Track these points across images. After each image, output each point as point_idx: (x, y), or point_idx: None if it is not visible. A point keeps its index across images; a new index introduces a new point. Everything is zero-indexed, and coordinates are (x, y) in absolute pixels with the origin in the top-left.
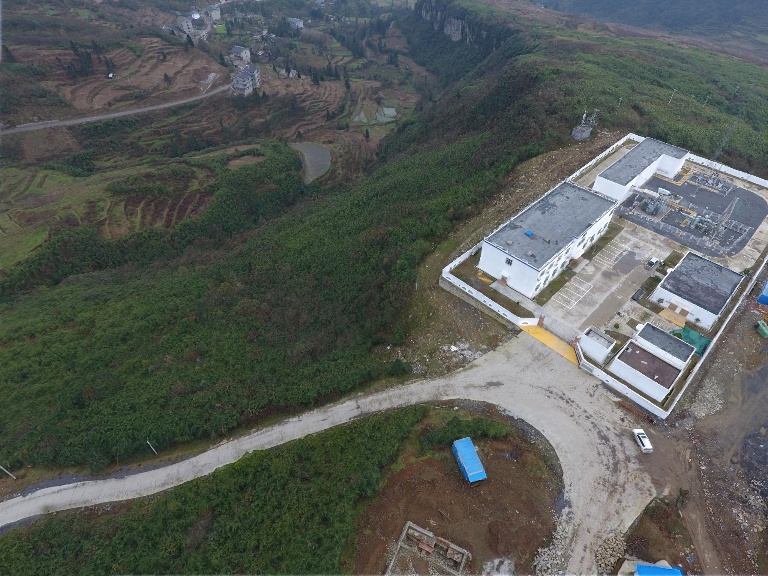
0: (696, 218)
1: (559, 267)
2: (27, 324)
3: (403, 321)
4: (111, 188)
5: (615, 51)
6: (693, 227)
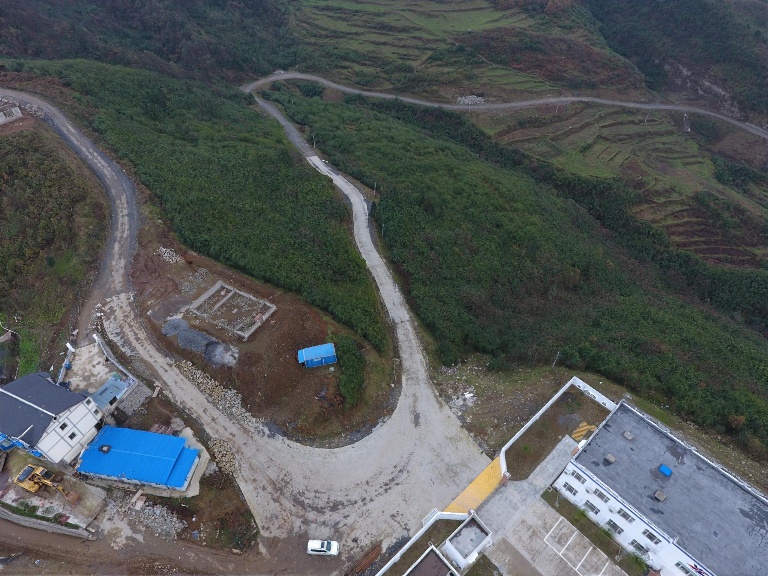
0: None
1: (627, 535)
2: (504, 185)
3: None
4: (699, 193)
5: None
6: None
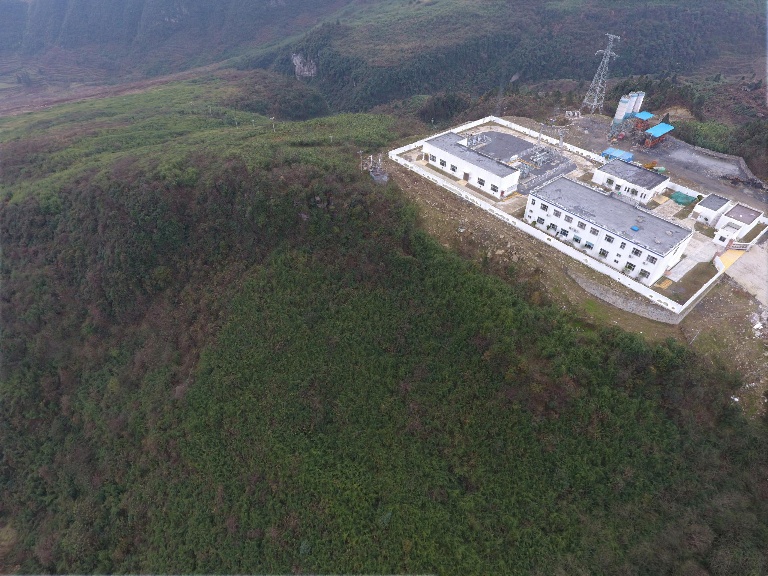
0: (541, 157)
1: None
2: None
3: (721, 371)
4: None
5: (75, 133)
6: (541, 164)
